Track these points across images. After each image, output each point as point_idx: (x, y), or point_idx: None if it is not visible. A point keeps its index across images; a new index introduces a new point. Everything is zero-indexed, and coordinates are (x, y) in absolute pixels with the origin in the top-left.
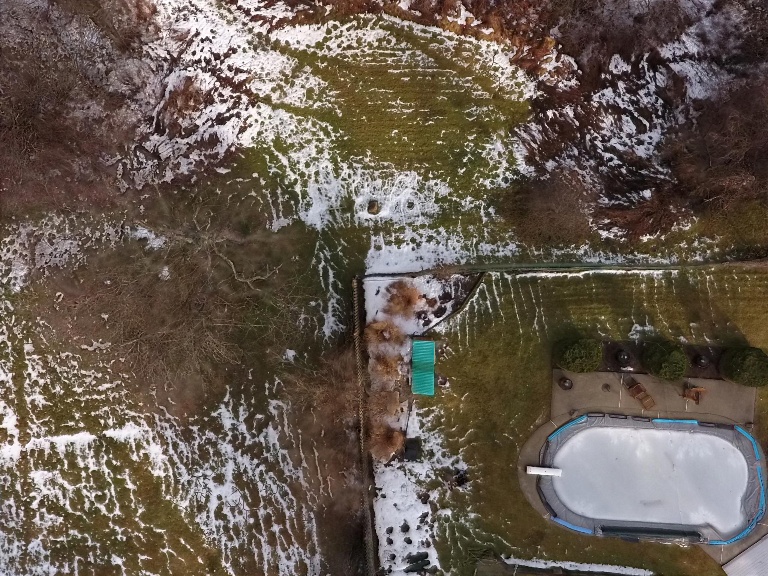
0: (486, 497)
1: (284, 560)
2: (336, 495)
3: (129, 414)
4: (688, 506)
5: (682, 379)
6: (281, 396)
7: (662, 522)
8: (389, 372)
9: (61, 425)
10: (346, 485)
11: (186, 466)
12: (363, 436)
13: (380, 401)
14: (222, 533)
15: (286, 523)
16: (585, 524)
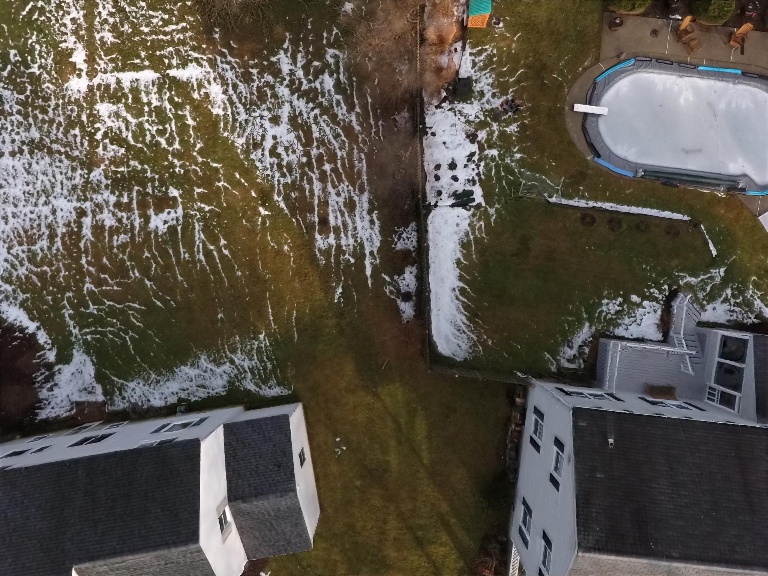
0: (533, 137)
1: (334, 196)
2: (387, 138)
3: (192, 55)
4: (728, 157)
5: (729, 29)
6: (338, 45)
7: (702, 171)
8: (445, 14)
9: (127, 62)
10: (397, 129)
11: (244, 106)
12: (419, 61)
13: (437, 30)
14: (276, 170)
15: (337, 162)
16: (627, 167)
